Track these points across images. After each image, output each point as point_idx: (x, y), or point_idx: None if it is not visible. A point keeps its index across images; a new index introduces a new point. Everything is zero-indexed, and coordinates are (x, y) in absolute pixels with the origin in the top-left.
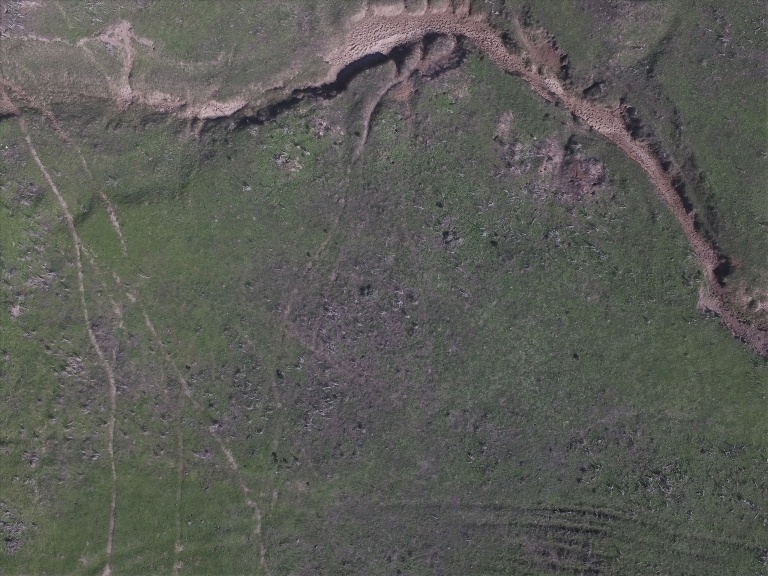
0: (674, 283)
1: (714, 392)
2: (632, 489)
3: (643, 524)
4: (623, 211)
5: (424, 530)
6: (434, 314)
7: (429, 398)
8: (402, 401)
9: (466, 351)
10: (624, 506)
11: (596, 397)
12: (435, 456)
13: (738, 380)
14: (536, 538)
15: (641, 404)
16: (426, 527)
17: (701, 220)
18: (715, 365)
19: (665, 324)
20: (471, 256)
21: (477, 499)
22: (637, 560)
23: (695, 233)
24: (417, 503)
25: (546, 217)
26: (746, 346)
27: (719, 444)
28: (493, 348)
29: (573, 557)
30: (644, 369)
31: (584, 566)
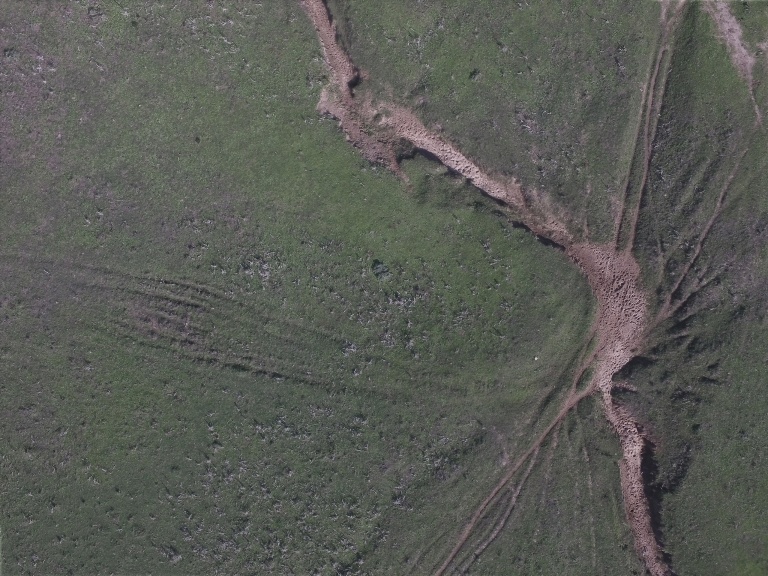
0: (297, 82)
1: (321, 189)
2: (234, 271)
3: (241, 305)
4: (259, 8)
5: (36, 283)
6: (71, 83)
7: (56, 161)
8: (30, 160)
9: (96, 122)
10: (225, 286)
11: (211, 180)
12: (54, 215)
13: (344, 181)
14: (140, 305)
15: (252, 192)
16: (38, 280)
17: (340, 32)
18: (325, 164)
19: (284, 120)
20: (111, 33)
21: (89, 261)
22: (230, 337)
23: (335, 45)
24: (32, 257)
25: (186, 5)
26: (355, 149)
27: (319, 238)
28: (122, 122)
29: (172, 327)
30: (259, 160)
31: (181, 336)
